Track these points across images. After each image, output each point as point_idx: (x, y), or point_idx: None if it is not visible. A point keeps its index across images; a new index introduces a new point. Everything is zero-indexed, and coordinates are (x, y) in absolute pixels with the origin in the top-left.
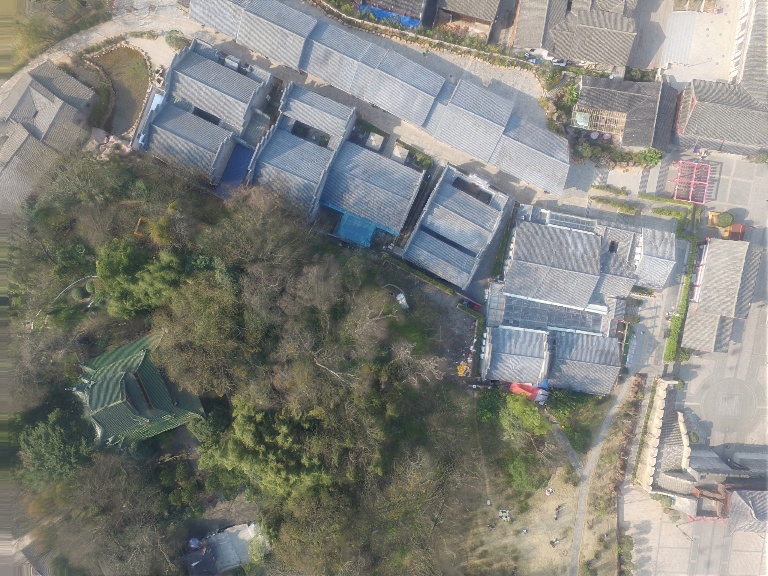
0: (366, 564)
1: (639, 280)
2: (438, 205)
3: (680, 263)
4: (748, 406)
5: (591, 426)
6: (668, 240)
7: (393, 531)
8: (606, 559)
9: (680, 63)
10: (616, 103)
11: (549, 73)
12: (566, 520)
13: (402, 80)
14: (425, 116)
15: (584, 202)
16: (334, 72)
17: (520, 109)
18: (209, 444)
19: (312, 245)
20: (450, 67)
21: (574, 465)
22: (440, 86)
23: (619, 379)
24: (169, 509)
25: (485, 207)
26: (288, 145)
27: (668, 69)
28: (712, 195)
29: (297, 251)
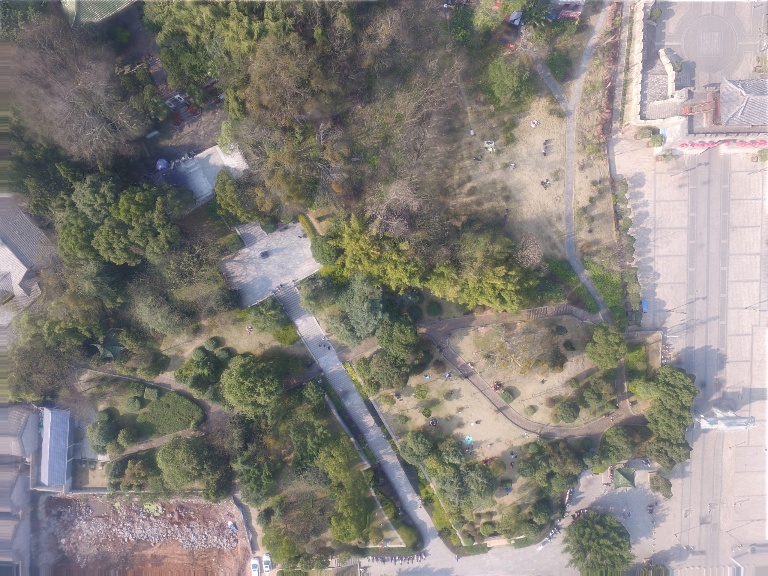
0: (348, 193)
1: None
2: None
3: None
4: (729, 43)
5: (571, 57)
6: None
7: (374, 160)
8: (602, 209)
9: None
10: None
11: None
12: (555, 160)
13: None
14: None
15: None
16: None
17: None
18: (165, 3)
19: None
20: None
21: (557, 98)
22: None
23: (594, 7)
24: (131, 114)
25: None
26: None
27: None
28: None
29: None
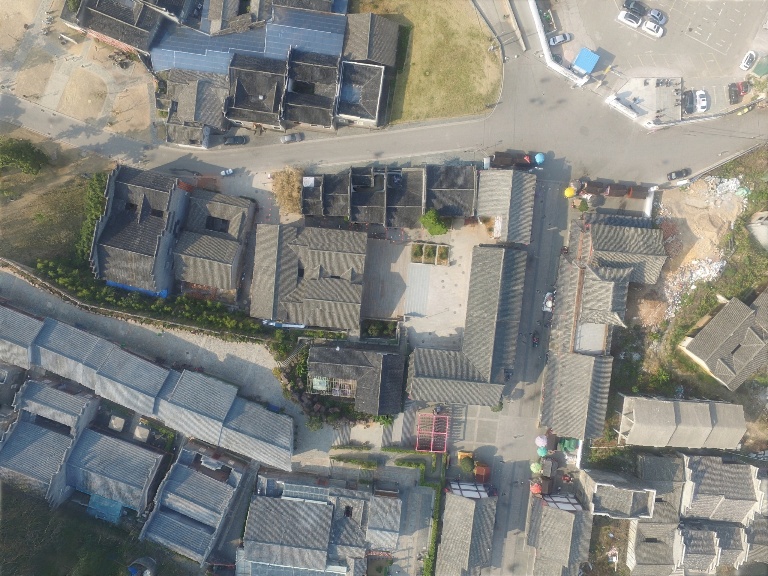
0: None
1: (371, 545)
2: (170, 493)
3: (427, 507)
4: None
5: None
6: (394, 508)
7: None
8: None
9: (419, 314)
10: (344, 373)
11: (281, 345)
12: None
13: (122, 382)
14: (151, 410)
15: (326, 462)
16: (65, 369)
17: (256, 380)
18: None
19: (43, 550)
20: (186, 345)
21: None
22: (162, 382)
23: None
24: None
25: (219, 486)
26: (28, 440)
27: (407, 321)
28: (460, 436)
29: (16, 572)
